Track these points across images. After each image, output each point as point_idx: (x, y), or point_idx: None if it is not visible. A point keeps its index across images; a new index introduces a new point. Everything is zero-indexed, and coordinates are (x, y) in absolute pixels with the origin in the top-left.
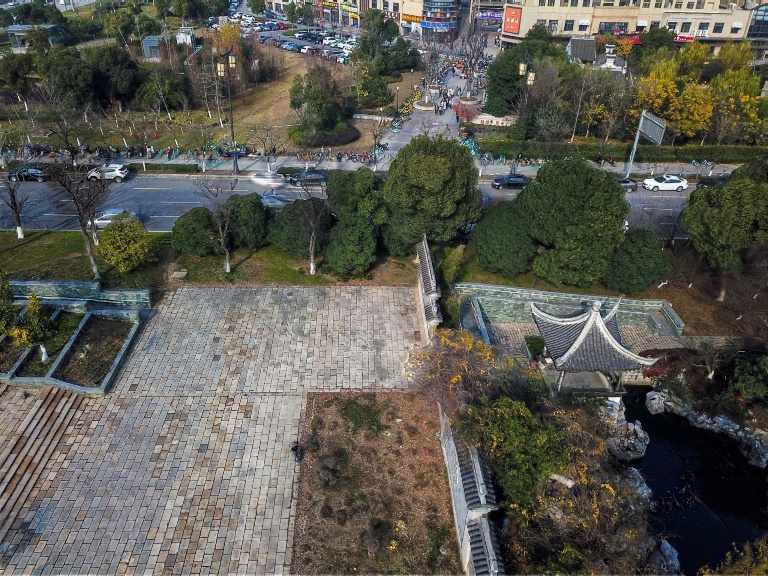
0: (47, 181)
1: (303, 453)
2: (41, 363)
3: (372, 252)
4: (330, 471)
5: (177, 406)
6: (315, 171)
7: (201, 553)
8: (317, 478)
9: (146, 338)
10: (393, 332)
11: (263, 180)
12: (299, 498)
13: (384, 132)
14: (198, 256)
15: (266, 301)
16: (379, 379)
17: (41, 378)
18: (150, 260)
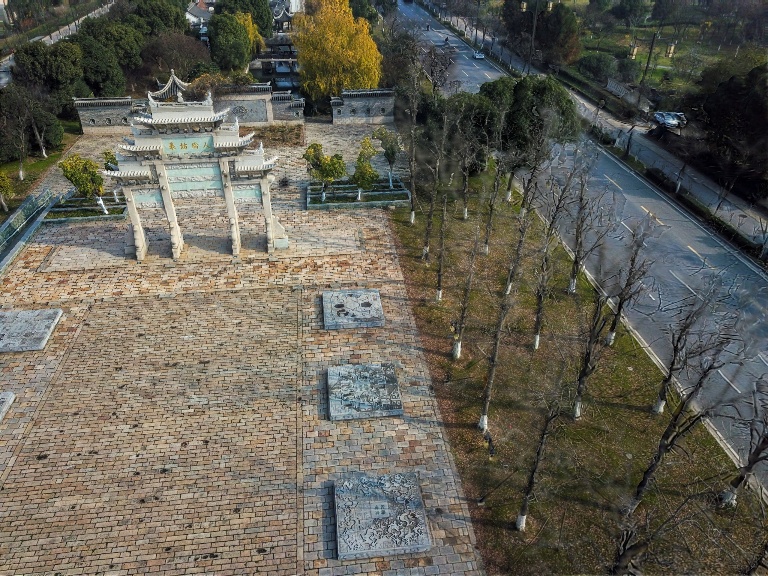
0: None
1: None
2: None
3: None
4: None
5: None
6: None
7: None
8: None
9: None
10: None
11: None
12: None
13: None
14: None
15: None
16: None
17: None
18: None
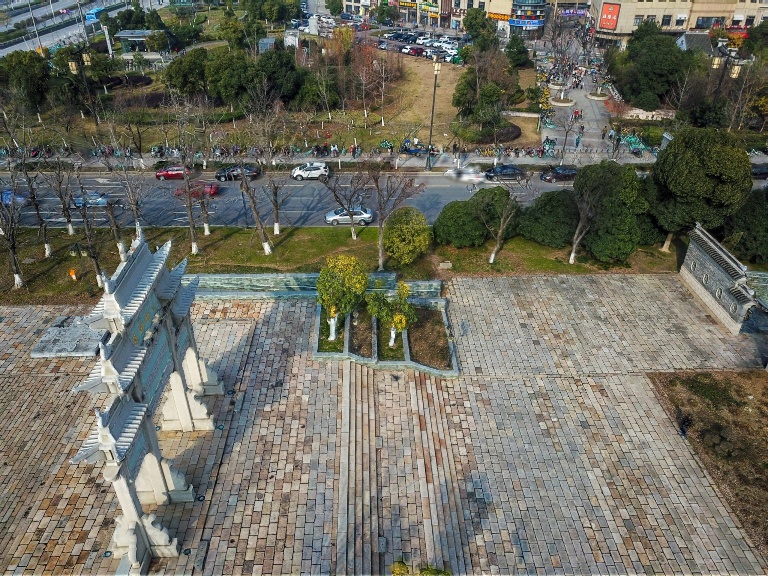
0: (254, 180)
1: (682, 428)
2: (390, 348)
3: (638, 241)
4: (730, 443)
5: (532, 387)
6: (507, 166)
7: (652, 518)
8: (719, 449)
9: (456, 325)
10: (685, 316)
11: (461, 176)
12: (707, 468)
13: (576, 127)
14: (454, 248)
15: (544, 289)
16: (704, 360)
17: (403, 362)
18: (424, 252)
